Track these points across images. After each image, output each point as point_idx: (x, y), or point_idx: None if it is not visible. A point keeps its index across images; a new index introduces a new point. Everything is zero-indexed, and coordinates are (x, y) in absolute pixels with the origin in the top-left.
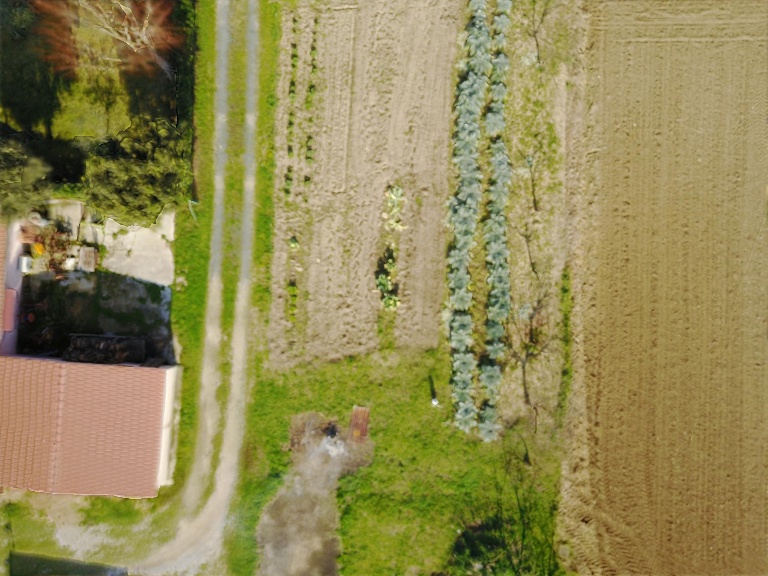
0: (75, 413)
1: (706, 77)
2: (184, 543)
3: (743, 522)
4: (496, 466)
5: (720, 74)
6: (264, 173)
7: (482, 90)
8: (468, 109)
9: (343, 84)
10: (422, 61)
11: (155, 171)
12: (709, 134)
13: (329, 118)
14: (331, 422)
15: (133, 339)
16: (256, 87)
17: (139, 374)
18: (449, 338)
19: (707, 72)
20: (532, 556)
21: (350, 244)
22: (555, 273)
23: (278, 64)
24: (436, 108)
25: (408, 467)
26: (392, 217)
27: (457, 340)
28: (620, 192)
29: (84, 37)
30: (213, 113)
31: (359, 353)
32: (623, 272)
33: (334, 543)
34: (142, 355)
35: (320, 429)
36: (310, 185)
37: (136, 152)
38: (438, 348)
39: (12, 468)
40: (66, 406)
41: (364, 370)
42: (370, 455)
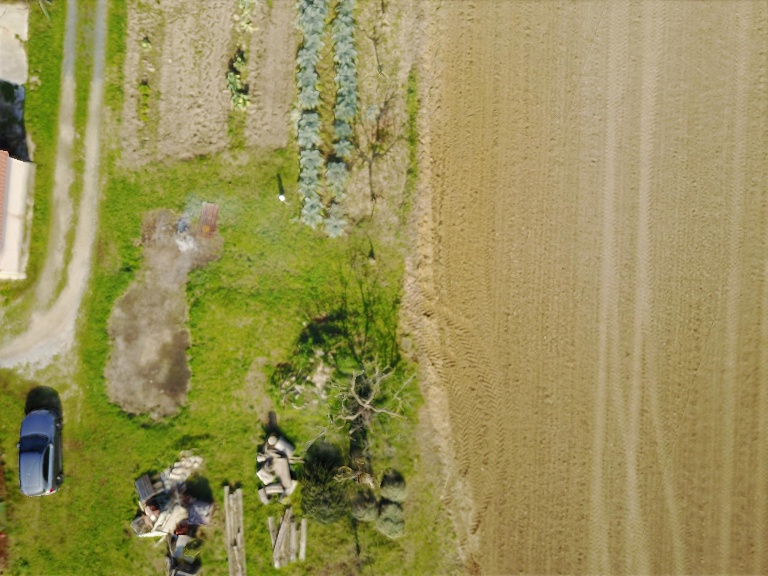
0: None
1: None
2: (36, 335)
3: (576, 312)
4: (341, 261)
5: None
6: None
7: None
8: None
9: None
10: None
11: None
12: None
13: None
14: (181, 219)
15: None
16: None
17: None
18: (297, 137)
19: None
20: (375, 348)
21: (202, 45)
22: (401, 75)
23: None
24: None
25: (256, 262)
26: (243, 19)
27: (303, 137)
28: None
29: None
30: None
31: (209, 152)
32: (467, 74)
33: (183, 336)
34: None
35: (170, 225)
36: None
37: None
38: (286, 147)
39: None
40: None
41: (214, 168)
42: (219, 251)
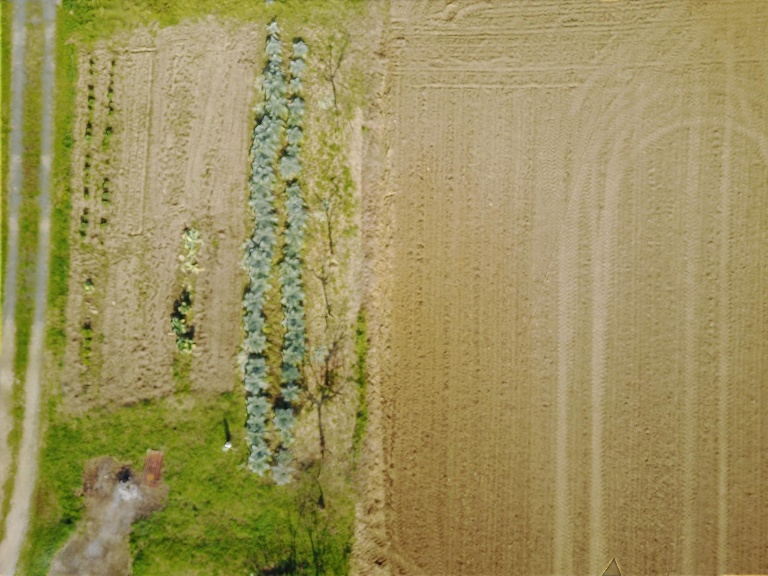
0: None
1: (497, 123)
2: None
3: (530, 562)
4: (290, 509)
5: (510, 120)
6: (59, 215)
7: (278, 134)
8: (262, 153)
9: (140, 126)
10: (220, 104)
11: None
12: (500, 179)
13: (126, 160)
14: (125, 466)
15: None
16: (52, 129)
17: None
18: (244, 381)
19: (497, 118)
20: None
21: (146, 286)
22: (351, 315)
23: (75, 106)
24: (233, 151)
25: (202, 511)
26: (189, 259)
27: (250, 383)
28: (414, 235)
29: None
30: (8, 154)
31: (154, 396)
32: (417, 314)
33: None
34: None
35: (113, 473)
36: (106, 227)
37: None
38: (233, 391)
39: None
40: None
41: (158, 413)
42: (164, 499)
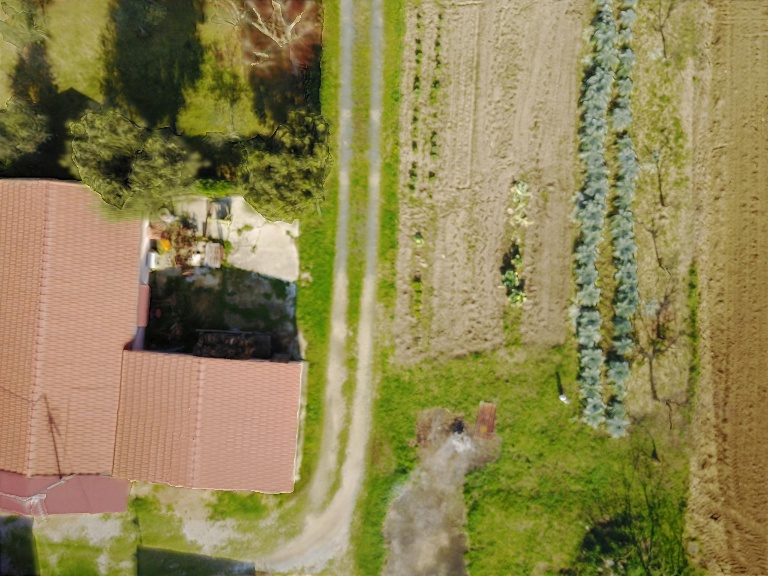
0: (213, 408)
1: None
2: (311, 538)
3: None
4: (624, 462)
5: None
6: (389, 169)
7: (609, 85)
8: (595, 104)
9: (467, 80)
10: (547, 56)
11: (312, 166)
12: None
13: (454, 114)
14: (457, 418)
15: (259, 335)
16: (380, 83)
17: (276, 369)
18: (576, 334)
19: None
20: (661, 553)
21: (475, 240)
22: (682, 269)
23: (402, 60)
24: (561, 103)
25: (535, 463)
26: (517, 213)
27: (585, 336)
28: (748, 187)
29: (208, 34)
30: (337, 109)
31: (485, 349)
32: (752, 268)
33: (461, 539)
34: (268, 351)
35: (446, 425)
36: (435, 181)
37: (294, 147)
38: (565, 344)
39: (150, 463)
40: (205, 401)
41: (490, 366)
42: (497, 451)
